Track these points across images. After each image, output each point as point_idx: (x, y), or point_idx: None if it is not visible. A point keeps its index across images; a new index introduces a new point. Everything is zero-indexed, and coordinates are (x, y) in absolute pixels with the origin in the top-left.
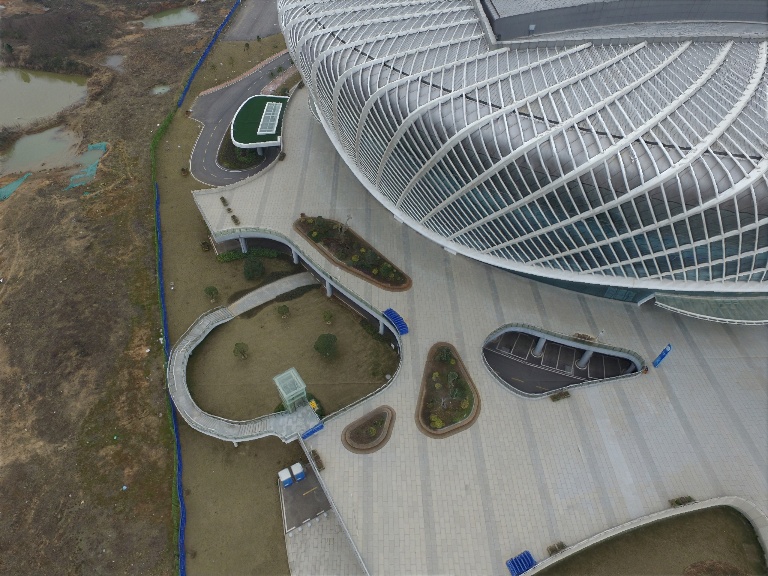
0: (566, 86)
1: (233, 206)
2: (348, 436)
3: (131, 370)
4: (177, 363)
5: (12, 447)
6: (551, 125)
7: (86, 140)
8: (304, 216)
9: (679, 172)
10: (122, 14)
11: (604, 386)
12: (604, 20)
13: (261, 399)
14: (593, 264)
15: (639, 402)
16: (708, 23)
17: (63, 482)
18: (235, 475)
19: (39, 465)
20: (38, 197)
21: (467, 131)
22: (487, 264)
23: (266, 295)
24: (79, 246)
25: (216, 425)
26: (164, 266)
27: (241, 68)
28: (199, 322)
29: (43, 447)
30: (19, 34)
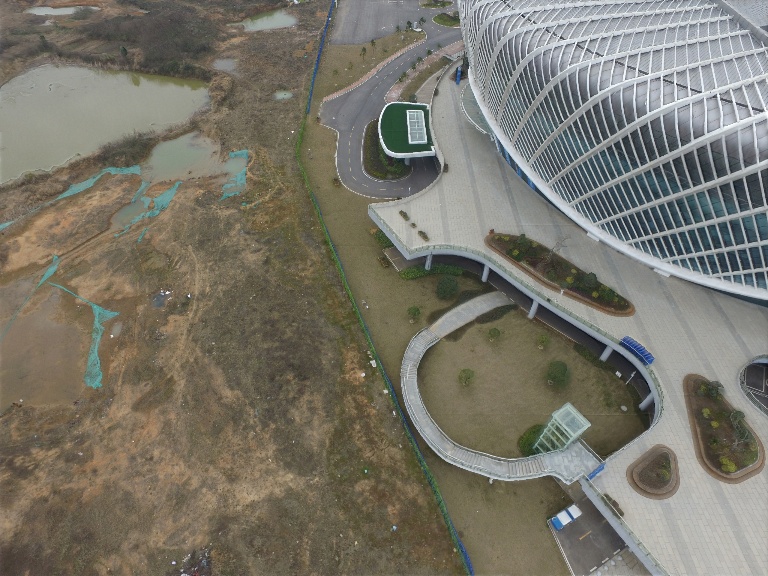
0: None
1: (415, 221)
2: (637, 479)
3: (354, 396)
4: (409, 390)
5: (262, 479)
6: None
7: (225, 147)
8: (493, 232)
9: None
10: (221, 16)
11: None
12: None
13: (499, 430)
14: None
15: None
16: None
17: (329, 520)
18: (501, 515)
19: (297, 500)
20: (198, 207)
21: None
22: (706, 288)
23: (464, 316)
24: (256, 260)
25: (481, 462)
26: (349, 283)
27: (357, 73)
28: (411, 345)
29: (294, 480)
30: (127, 37)
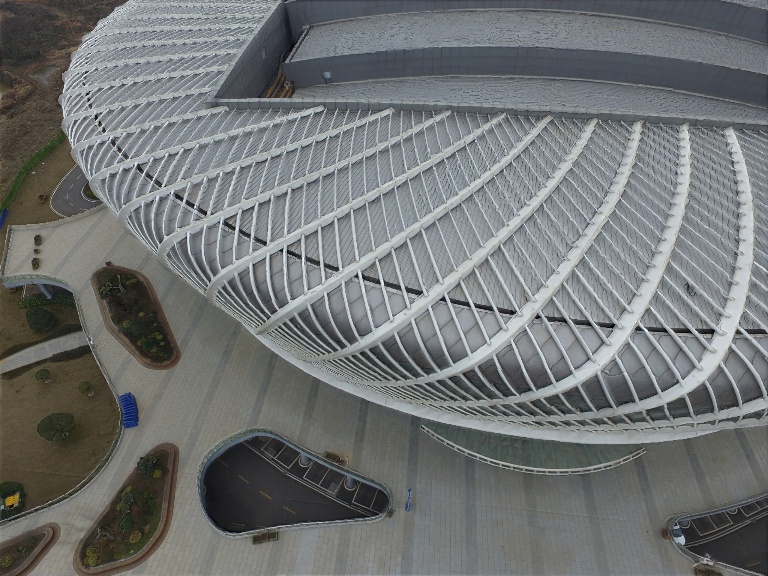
0: (249, 164)
1: (45, 246)
2: None
3: None
4: None
5: None
6: (199, 217)
7: None
8: (110, 265)
9: (313, 301)
10: (78, 25)
11: (328, 530)
12: (411, 70)
13: None
14: None
15: (360, 559)
16: (543, 79)
17: None
18: None
19: None
20: None
21: (122, 212)
22: None
23: (44, 352)
24: None
25: None
26: None
27: None
28: None
29: None
30: None
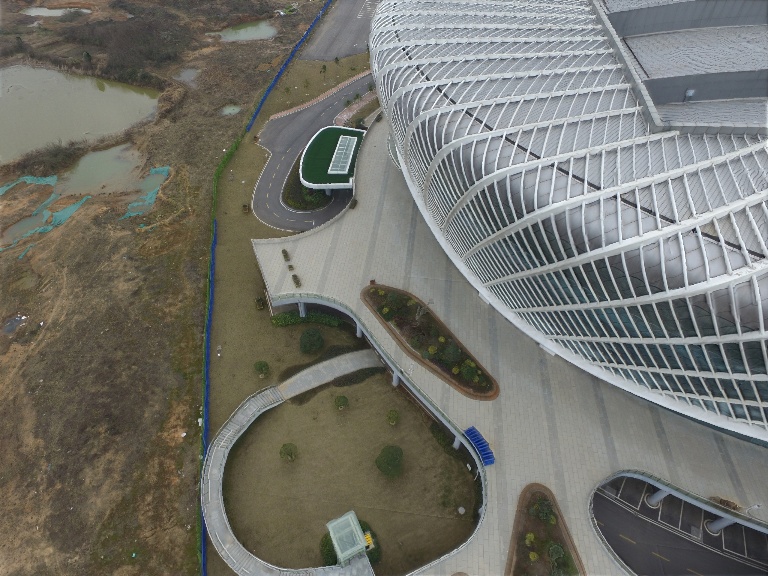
0: None
1: (295, 262)
2: None
3: (162, 459)
4: (214, 462)
5: (19, 550)
6: (752, 258)
7: (149, 162)
8: (374, 283)
9: None
10: (201, 25)
11: None
12: None
13: (306, 521)
14: (756, 417)
15: None
16: None
17: None
18: None
19: None
20: (93, 226)
21: (621, 248)
22: None
23: (322, 375)
24: (126, 290)
25: (251, 565)
26: (213, 324)
27: (315, 91)
28: (244, 405)
29: (52, 556)
30: (100, 42)
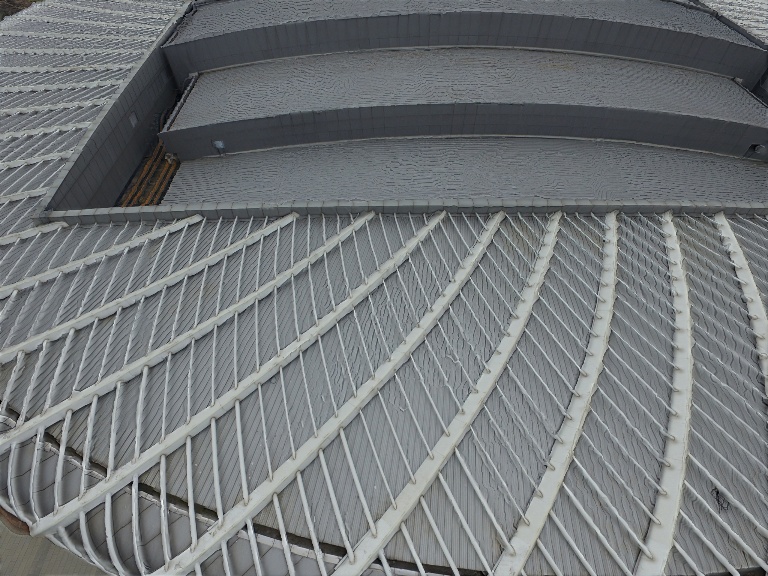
0: (89, 324)
1: None
2: None
3: None
4: None
5: None
6: (6, 426)
7: None
8: None
9: None
10: None
11: None
12: (325, 135)
13: None
14: None
15: None
16: (486, 138)
17: None
18: None
19: None
20: None
21: None
22: None
23: None
24: None
25: None
26: None
27: None
28: None
29: None
30: None
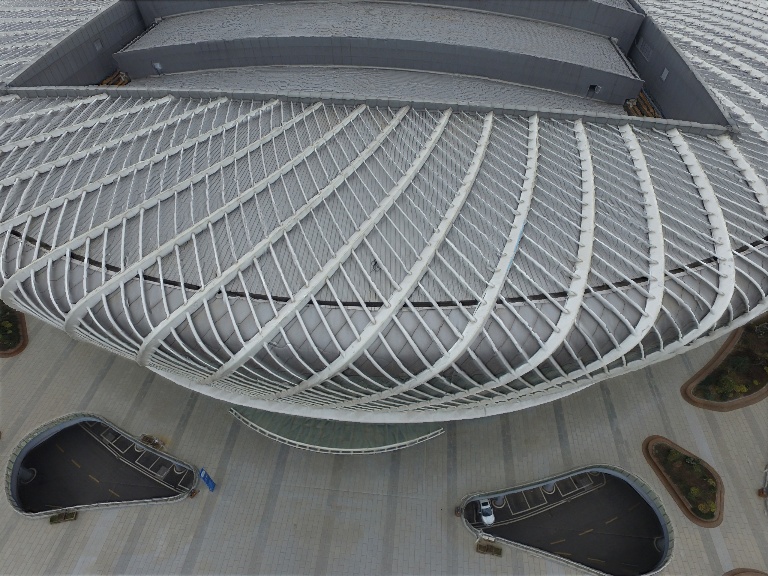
0: (12, 149)
1: None
2: None
3: None
4: None
5: None
6: None
7: None
8: None
9: (24, 279)
10: None
11: (128, 510)
12: (236, 61)
13: None
14: None
15: (152, 538)
16: (363, 69)
17: None
18: None
19: None
20: None
21: None
22: None
23: None
24: None
25: None
26: None
27: None
28: None
29: None
30: None
